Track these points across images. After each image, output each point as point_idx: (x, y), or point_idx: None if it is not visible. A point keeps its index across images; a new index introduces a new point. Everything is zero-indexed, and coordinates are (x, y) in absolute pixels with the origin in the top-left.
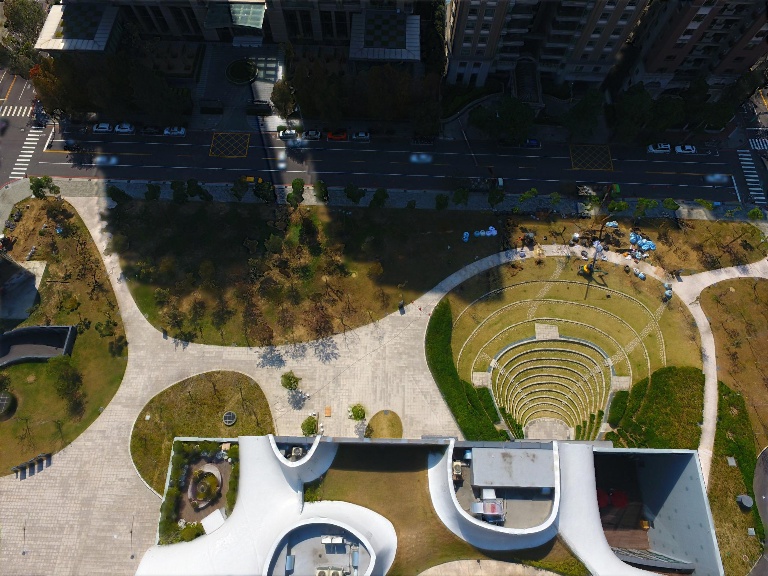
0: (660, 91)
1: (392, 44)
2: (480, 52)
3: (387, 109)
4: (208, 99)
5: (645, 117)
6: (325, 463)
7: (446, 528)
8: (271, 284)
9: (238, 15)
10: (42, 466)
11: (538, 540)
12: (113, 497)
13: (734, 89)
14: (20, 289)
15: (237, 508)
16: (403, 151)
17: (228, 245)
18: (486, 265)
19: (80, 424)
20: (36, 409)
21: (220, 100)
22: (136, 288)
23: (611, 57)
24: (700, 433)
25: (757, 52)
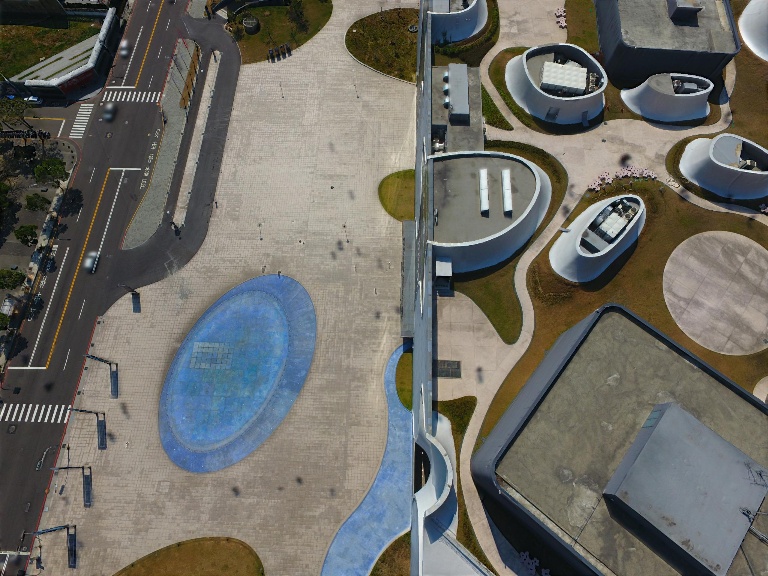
0: None
1: None
2: None
3: None
4: None
5: None
6: None
7: None
8: None
9: None
10: (285, 56)
11: None
12: (339, 70)
13: None
14: None
15: None
16: None
17: None
18: None
19: (307, 35)
20: (274, 28)
21: None
22: None
23: None
24: None
25: None
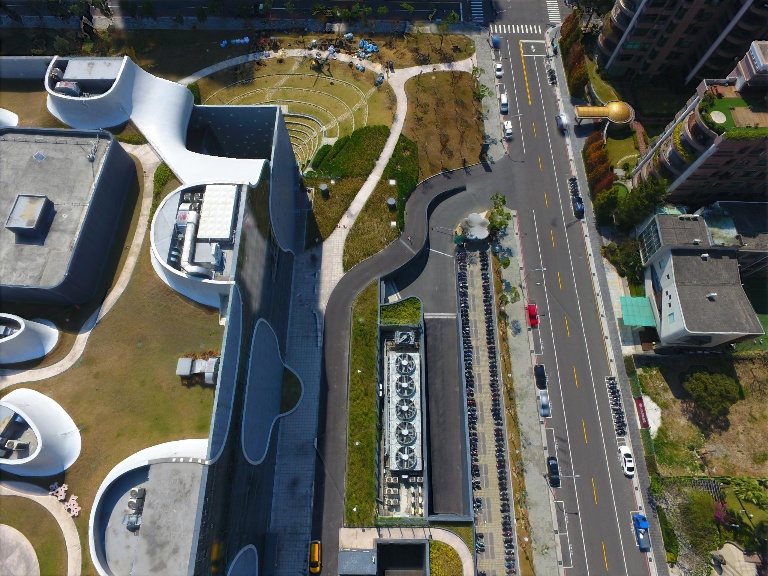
0: None
1: None
2: None
3: None
4: None
5: None
6: None
7: (51, 114)
8: None
9: None
10: None
11: (114, 122)
12: None
13: None
14: None
15: None
16: None
17: None
18: (235, 62)
19: None
20: None
21: None
22: None
23: None
24: (374, 165)
25: None
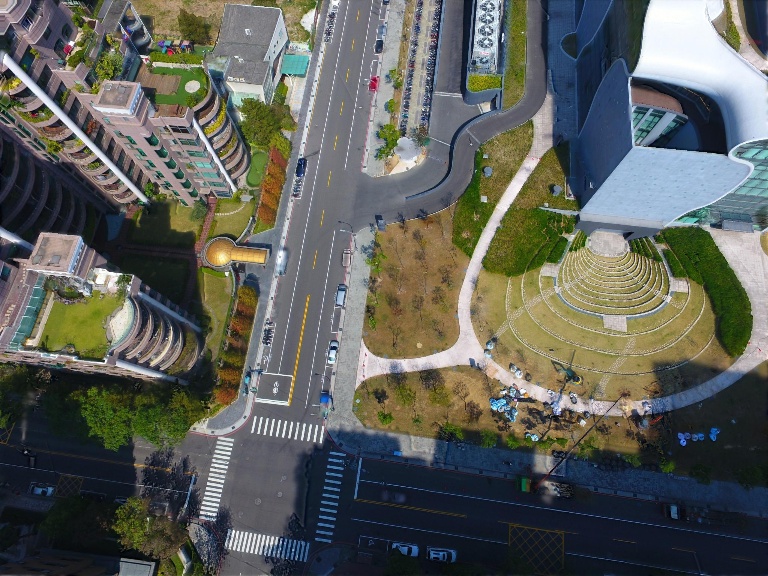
0: None
1: None
2: None
3: None
4: None
5: None
6: None
7: None
8: None
9: None
10: None
11: None
12: None
13: None
14: None
15: None
16: None
17: None
18: (689, 395)
19: None
20: None
21: None
22: None
23: None
24: None
25: None
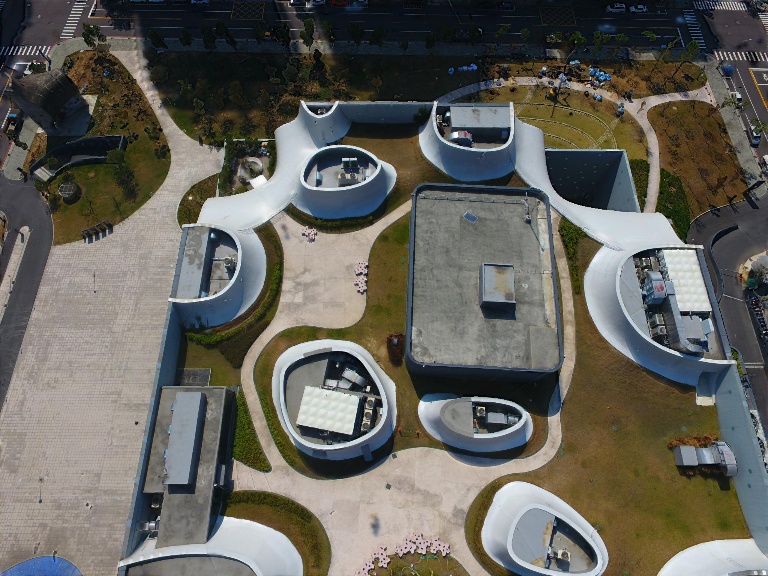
0: None
1: None
2: None
3: None
4: None
5: None
6: (342, 131)
7: (432, 165)
8: (288, 106)
9: None
10: (105, 234)
11: (500, 173)
12: (165, 252)
13: None
14: (77, 115)
15: (277, 168)
16: (397, 13)
17: (250, 81)
18: (468, 91)
19: (135, 204)
20: (97, 195)
21: None
22: (174, 112)
23: None
24: (644, 203)
25: None
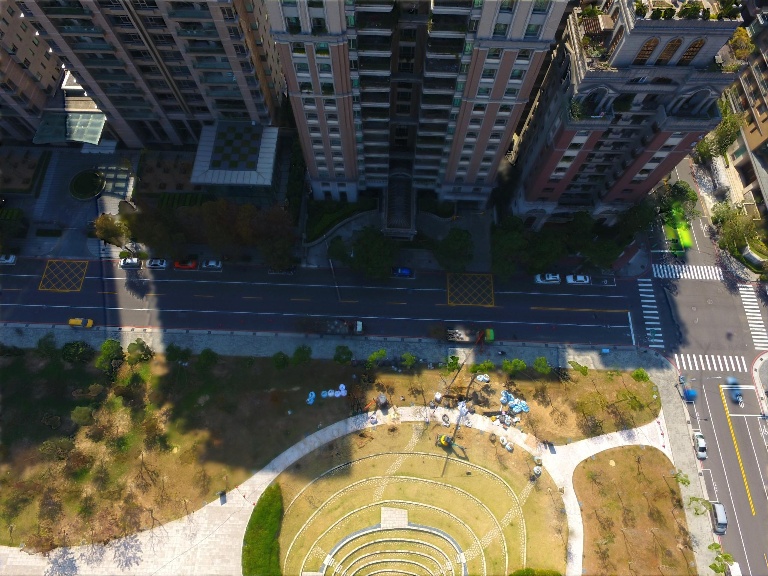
0: (547, 216)
1: (241, 165)
2: (341, 173)
3: (230, 244)
4: (43, 221)
5: (520, 257)
6: None
7: None
8: (79, 462)
9: (74, 127)
10: None
11: None
12: None
13: (626, 220)
14: None
15: None
16: (258, 283)
17: (40, 408)
18: (330, 435)
19: None
20: None
21: (56, 222)
22: None
23: (489, 180)
24: None
25: (646, 185)
